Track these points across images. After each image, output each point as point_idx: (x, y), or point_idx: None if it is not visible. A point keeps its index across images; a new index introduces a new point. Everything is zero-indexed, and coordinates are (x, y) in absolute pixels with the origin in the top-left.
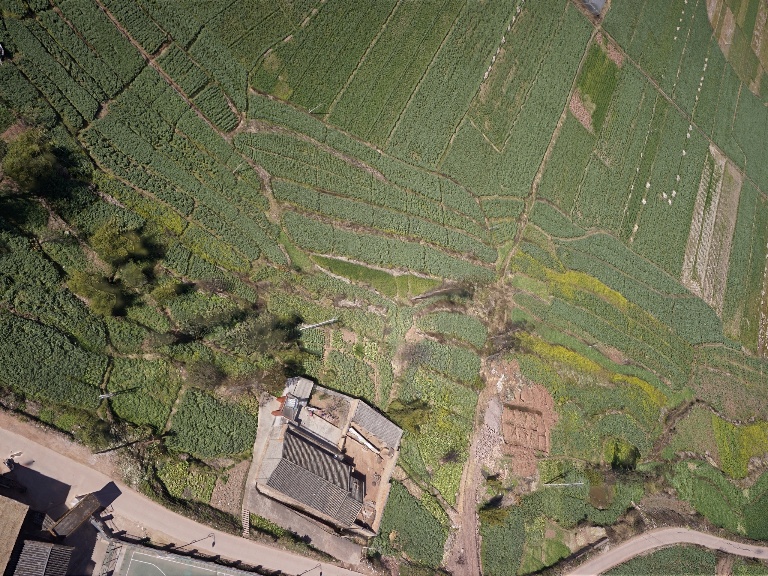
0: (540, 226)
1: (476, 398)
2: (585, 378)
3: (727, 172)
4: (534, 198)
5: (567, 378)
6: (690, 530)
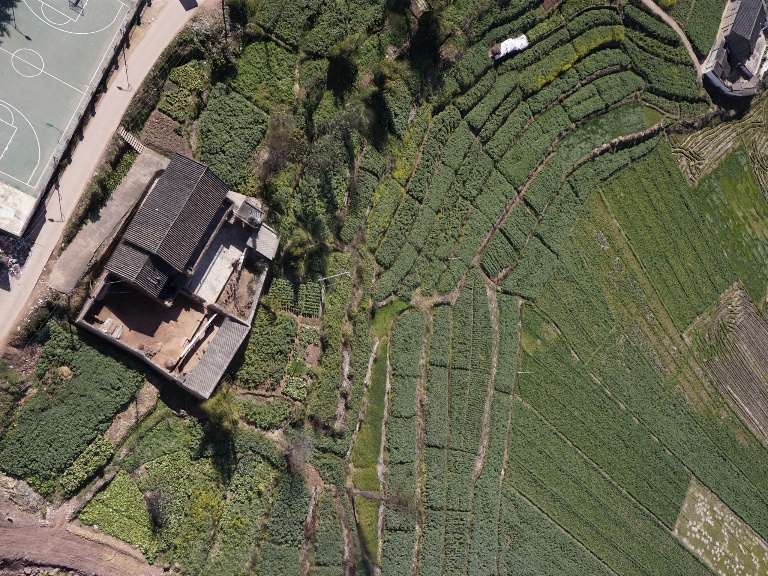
0: None
1: None
2: None
3: None
4: None
5: None
6: None
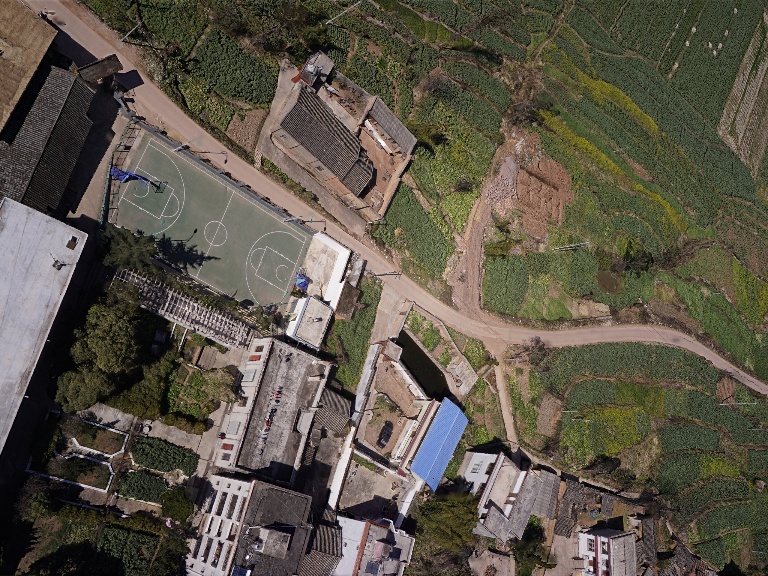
0: (577, 31)
1: (493, 149)
2: (606, 177)
3: None
4: (574, 3)
5: (588, 169)
6: (696, 341)
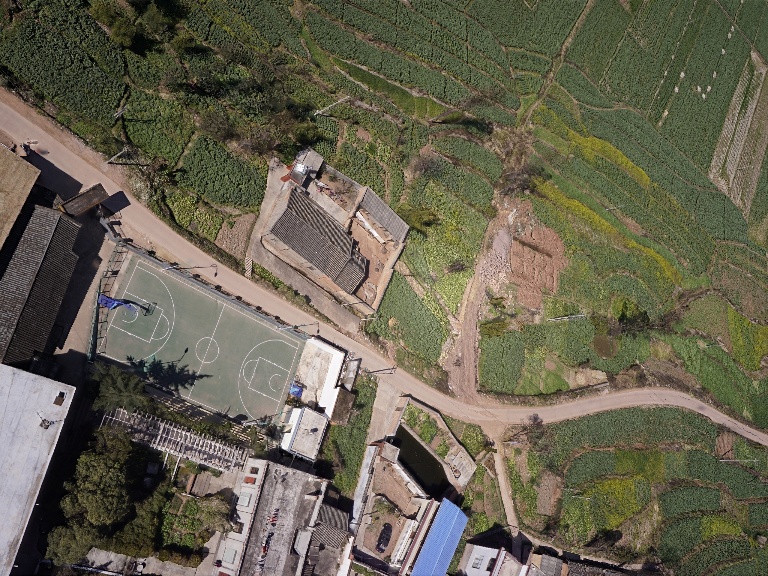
0: (566, 88)
1: (486, 224)
2: (599, 237)
3: (767, 81)
4: (562, 60)
5: (581, 232)
6: (693, 398)
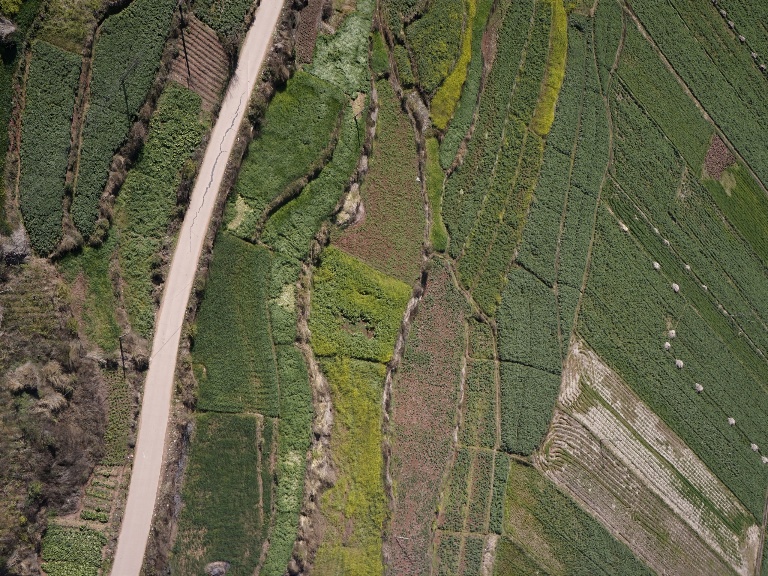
0: (600, 2)
1: None
2: None
3: None
4: (623, 7)
5: None
6: None
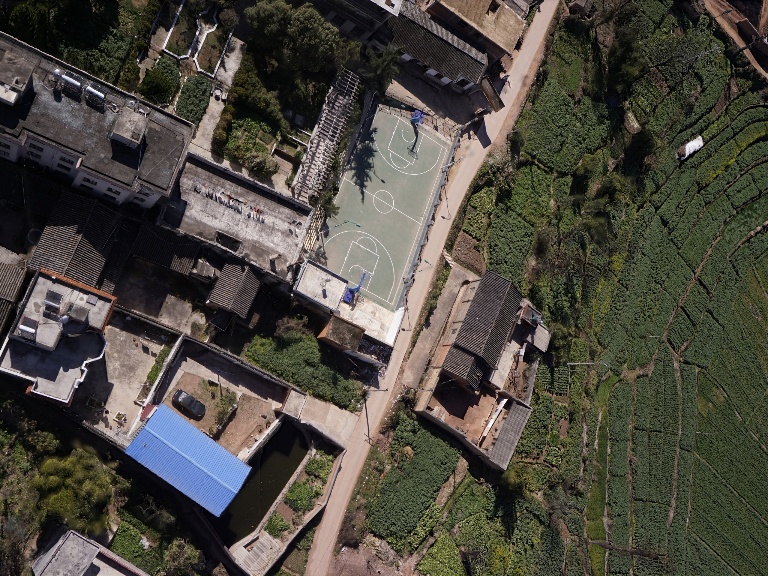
0: None
1: None
2: None
3: None
4: None
5: None
6: None
